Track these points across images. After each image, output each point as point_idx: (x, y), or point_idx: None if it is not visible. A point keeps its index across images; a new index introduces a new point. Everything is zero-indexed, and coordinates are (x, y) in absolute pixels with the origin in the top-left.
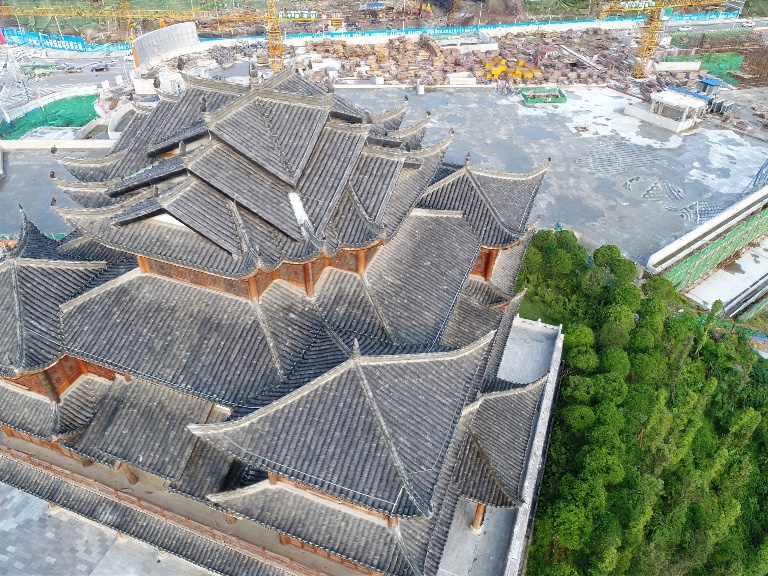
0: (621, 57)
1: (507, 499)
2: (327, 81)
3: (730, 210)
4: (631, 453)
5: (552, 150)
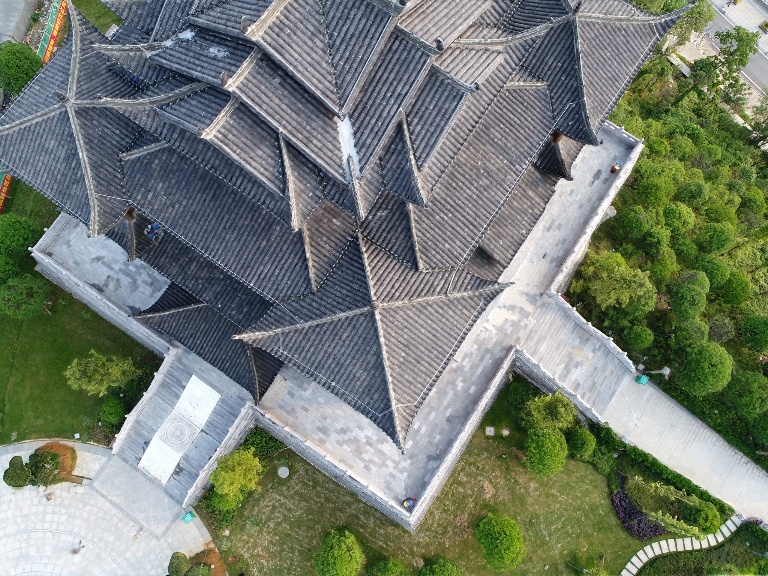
0: None
1: None
2: None
3: None
4: None
5: None
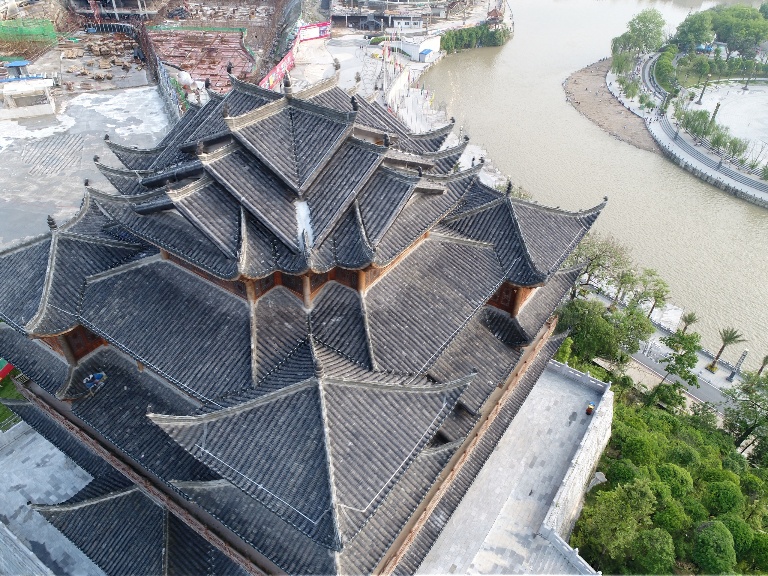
0: None
1: None
2: (336, 60)
3: None
4: None
5: None
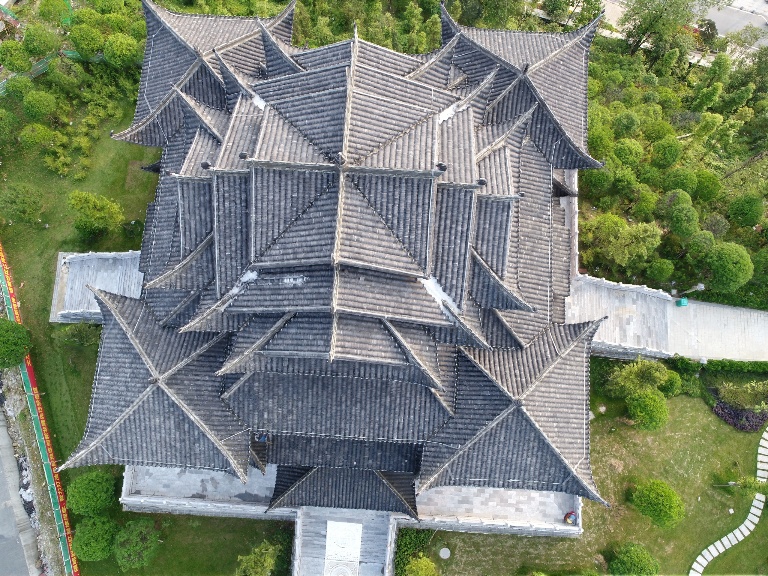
0: None
1: None
2: (347, 71)
3: None
4: None
5: None
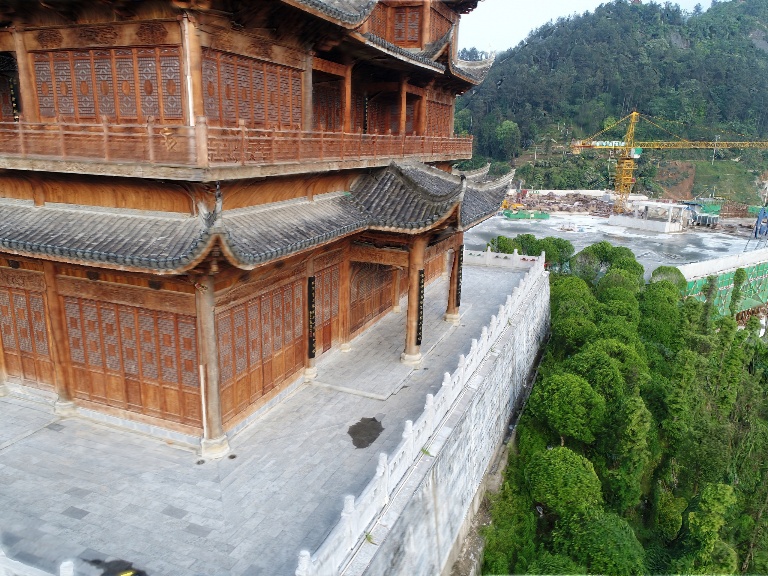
0: (601, 203)
1: (442, 205)
2: None
3: (735, 257)
4: (656, 368)
5: (536, 236)
